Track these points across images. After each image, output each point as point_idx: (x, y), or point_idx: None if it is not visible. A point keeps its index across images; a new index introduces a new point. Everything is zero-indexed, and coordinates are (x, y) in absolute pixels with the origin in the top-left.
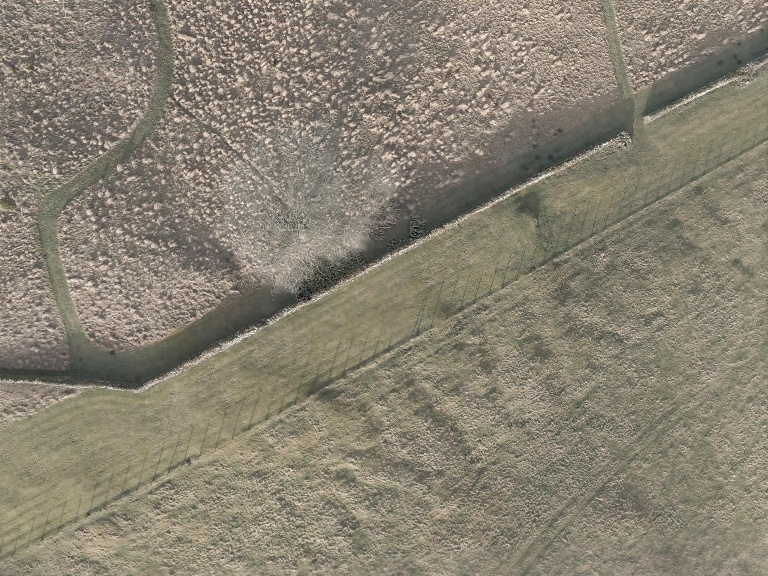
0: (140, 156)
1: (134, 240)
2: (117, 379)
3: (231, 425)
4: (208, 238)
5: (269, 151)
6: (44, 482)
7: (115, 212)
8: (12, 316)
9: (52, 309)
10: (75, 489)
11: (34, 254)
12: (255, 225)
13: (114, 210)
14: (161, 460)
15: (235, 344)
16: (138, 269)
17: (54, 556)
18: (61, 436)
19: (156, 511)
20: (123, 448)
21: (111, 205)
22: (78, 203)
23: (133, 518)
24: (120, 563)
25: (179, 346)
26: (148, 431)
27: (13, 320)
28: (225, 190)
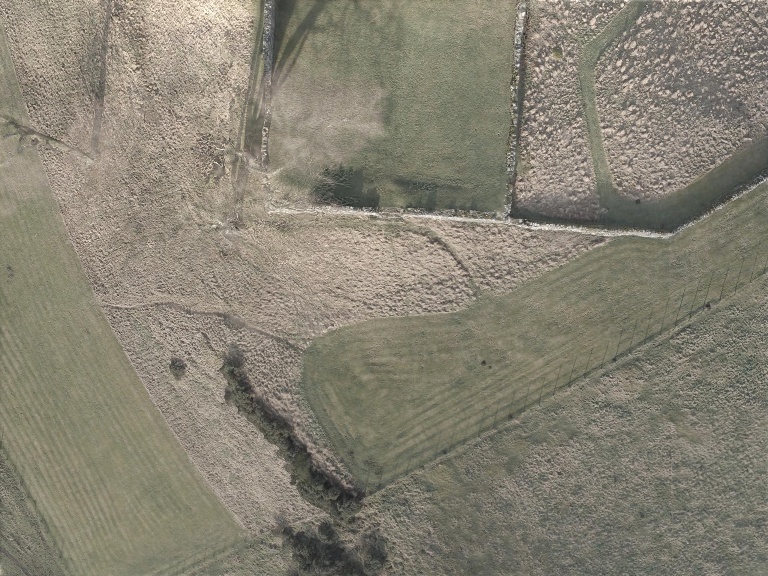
0: (651, 10)
1: (656, 91)
2: (644, 227)
3: (749, 269)
4: (717, 89)
5: (765, 3)
6: (571, 331)
7: (640, 63)
8: (558, 165)
9: (588, 159)
10: (603, 336)
11: (577, 103)
12: (761, 74)
13: (637, 61)
14: (682, 306)
15: (752, 190)
16: (662, 119)
17: (579, 402)
18: (589, 285)
19: (678, 355)
20: (646, 295)
21: (634, 57)
22: (609, 54)
23: (656, 363)
24: (643, 407)
25: (700, 193)
26: (670, 277)
27: (558, 169)
28: (727, 42)
